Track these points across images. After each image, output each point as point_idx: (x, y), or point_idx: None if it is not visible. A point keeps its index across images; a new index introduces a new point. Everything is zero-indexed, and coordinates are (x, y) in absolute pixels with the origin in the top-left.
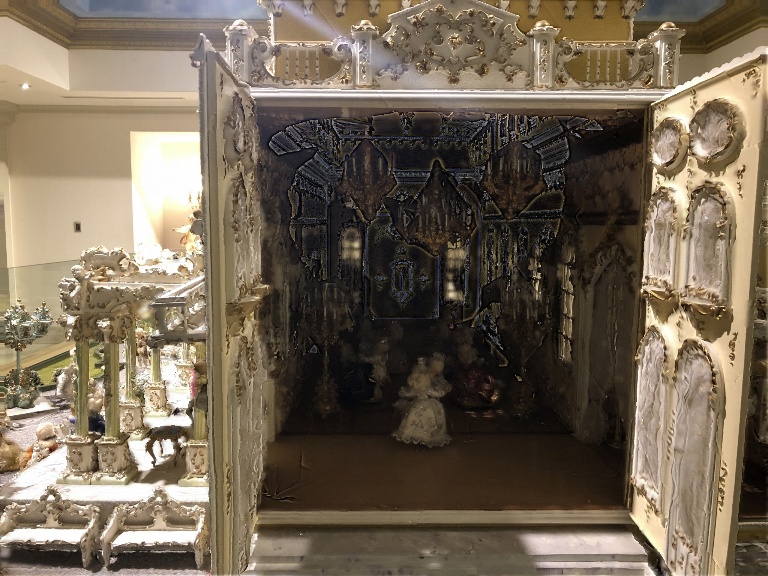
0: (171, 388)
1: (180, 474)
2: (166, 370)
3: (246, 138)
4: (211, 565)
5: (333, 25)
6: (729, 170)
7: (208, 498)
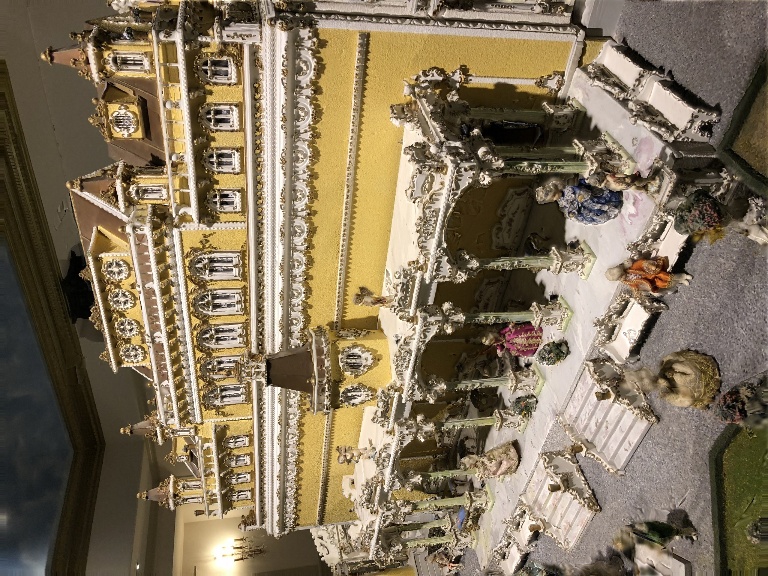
0: (542, 380)
1: (582, 136)
2: (535, 481)
3: None
4: None
5: None
6: None
7: (581, 77)
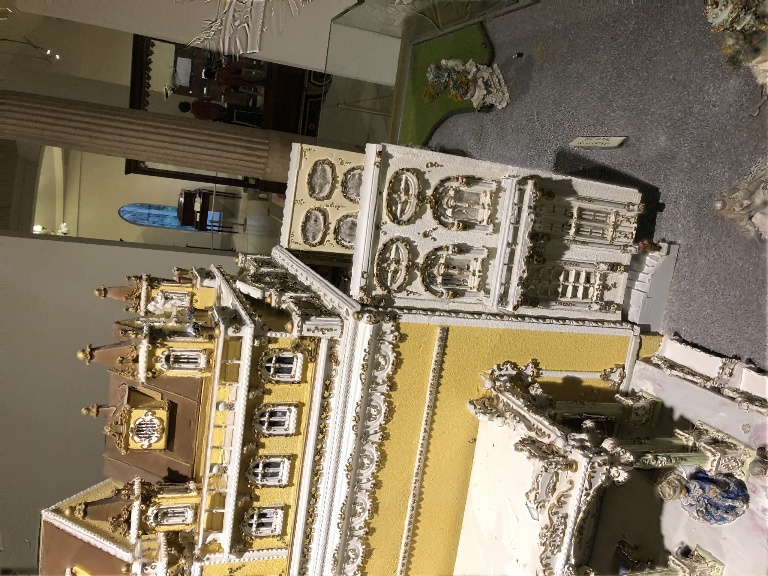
0: None
1: (663, 428)
2: None
3: None
4: (614, 186)
5: (267, 320)
6: (338, 171)
7: (645, 369)
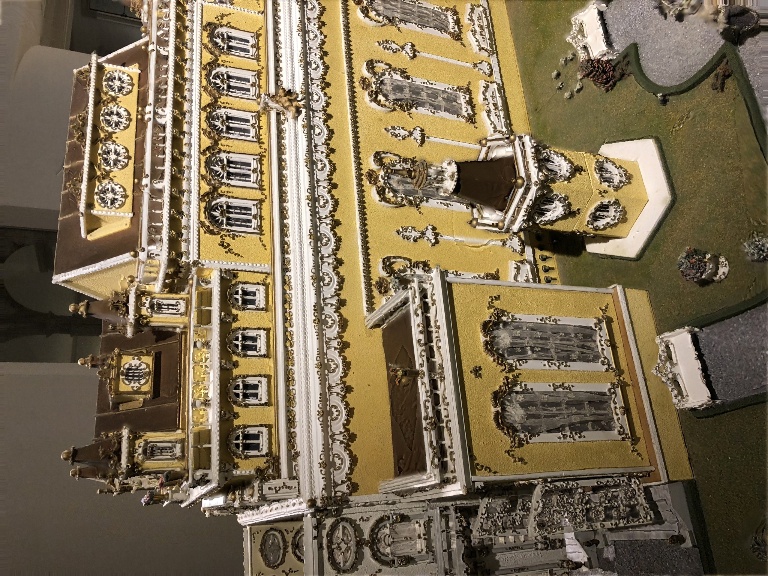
0: None
1: None
2: None
3: (274, 568)
4: None
5: None
6: None
7: None
